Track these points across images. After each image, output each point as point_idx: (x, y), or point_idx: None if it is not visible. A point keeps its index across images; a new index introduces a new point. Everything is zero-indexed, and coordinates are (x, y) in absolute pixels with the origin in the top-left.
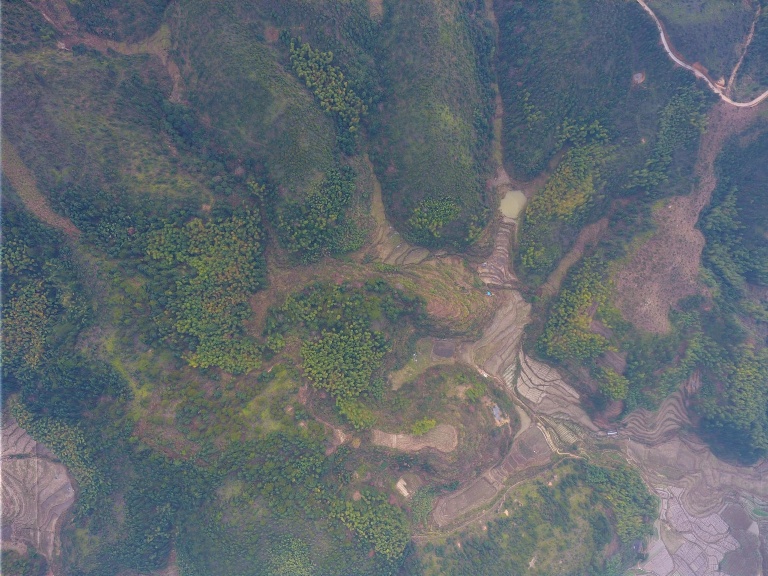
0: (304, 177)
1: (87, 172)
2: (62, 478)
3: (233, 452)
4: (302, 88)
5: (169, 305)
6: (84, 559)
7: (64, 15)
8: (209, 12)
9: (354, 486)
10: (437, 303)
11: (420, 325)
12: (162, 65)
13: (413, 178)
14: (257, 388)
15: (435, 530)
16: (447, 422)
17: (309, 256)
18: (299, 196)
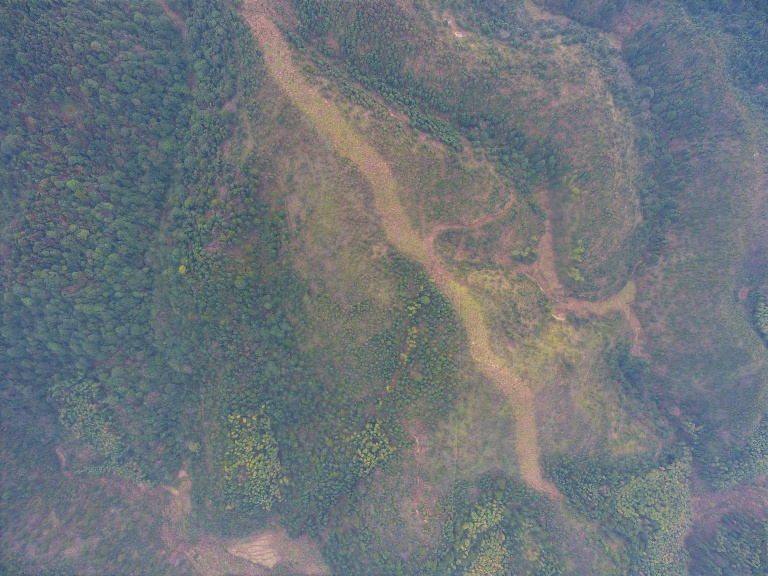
0: (751, 423)
1: (585, 444)
2: None
3: None
4: None
5: (644, 566)
6: None
7: (552, 282)
8: (714, 290)
9: None
10: None
11: None
12: (628, 321)
13: None
14: None
15: None
16: None
17: None
18: (743, 440)
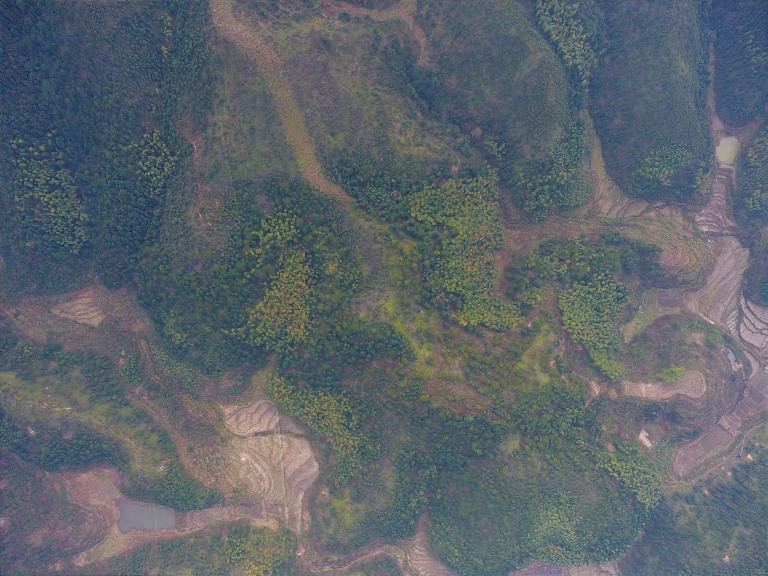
0: (548, 132)
1: (362, 136)
2: (306, 452)
3: (522, 404)
4: (546, 43)
5: (439, 265)
6: (348, 528)
7: None
8: None
9: (606, 438)
10: (667, 252)
11: (648, 276)
12: (410, 30)
13: (646, 127)
14: (526, 342)
15: (678, 479)
16: (694, 368)
17: (540, 214)
18: (542, 152)
